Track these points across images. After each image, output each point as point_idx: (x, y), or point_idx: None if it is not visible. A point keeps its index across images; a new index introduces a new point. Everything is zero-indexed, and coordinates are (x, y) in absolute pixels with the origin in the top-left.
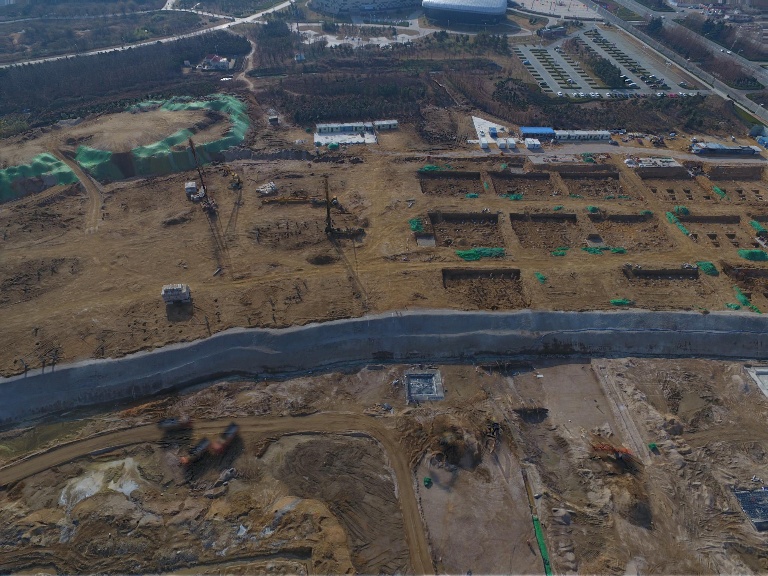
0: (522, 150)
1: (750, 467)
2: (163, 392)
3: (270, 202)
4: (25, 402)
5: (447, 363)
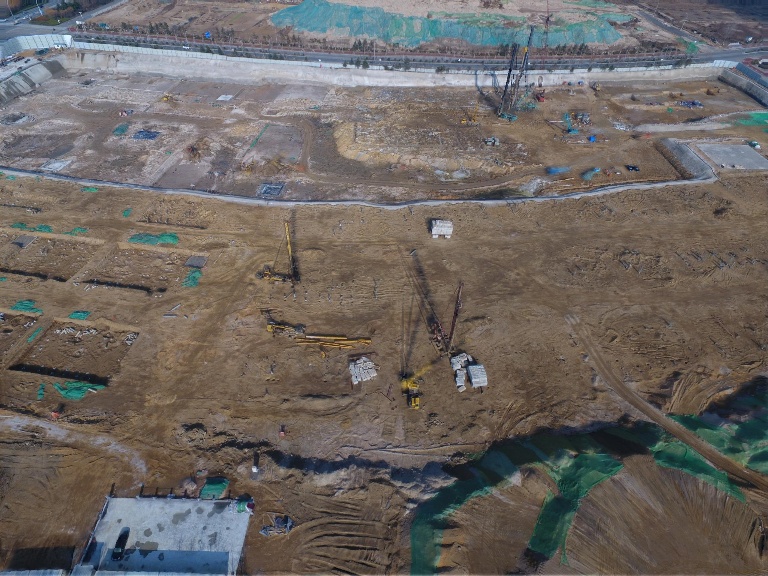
0: None
1: (132, 143)
2: None
3: (360, 339)
4: None
5: None
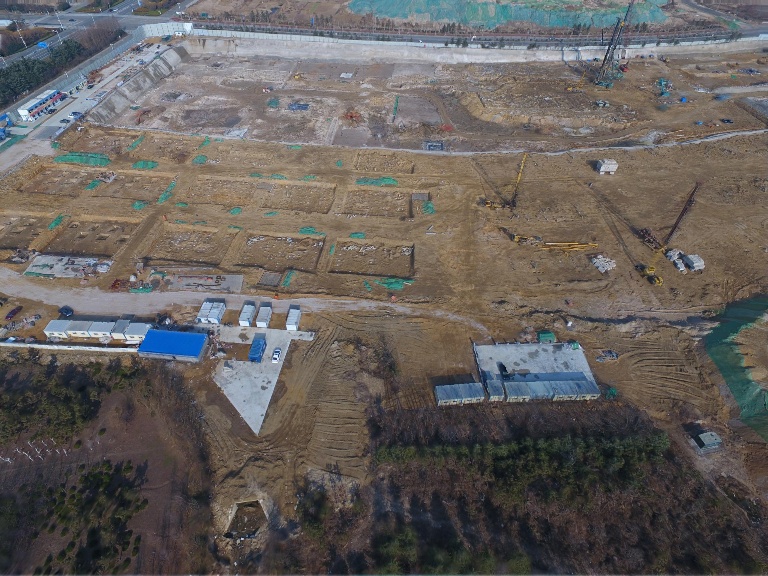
0: (238, 305)
1: None
2: None
3: None
4: None
5: None
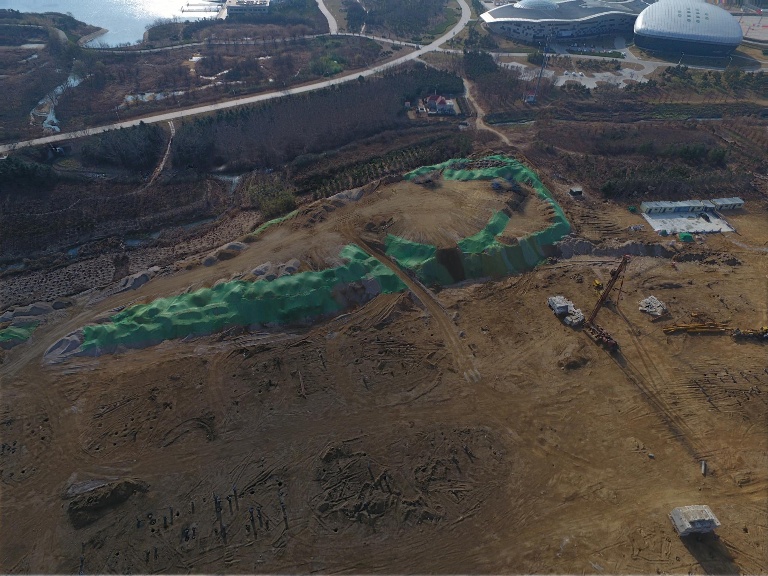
0: None
1: None
2: None
3: (675, 332)
4: None
5: None
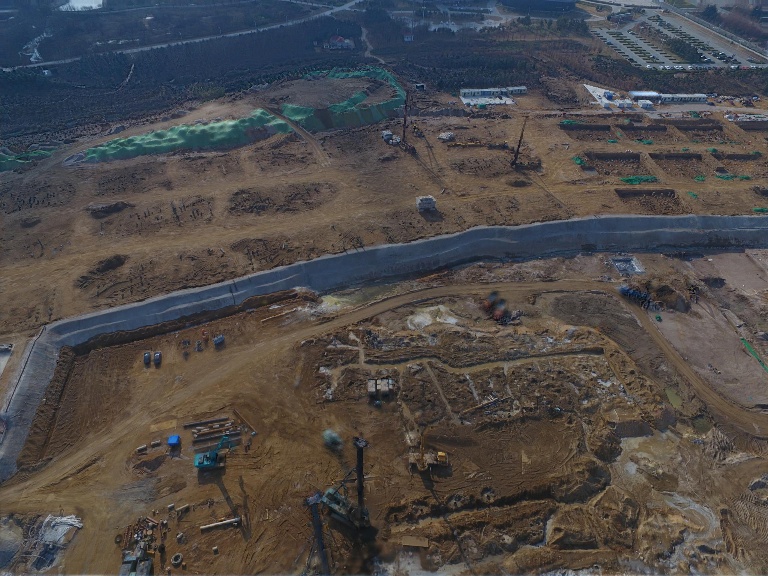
0: (638, 109)
1: None
2: (439, 269)
3: (454, 146)
4: (350, 271)
5: (638, 252)
